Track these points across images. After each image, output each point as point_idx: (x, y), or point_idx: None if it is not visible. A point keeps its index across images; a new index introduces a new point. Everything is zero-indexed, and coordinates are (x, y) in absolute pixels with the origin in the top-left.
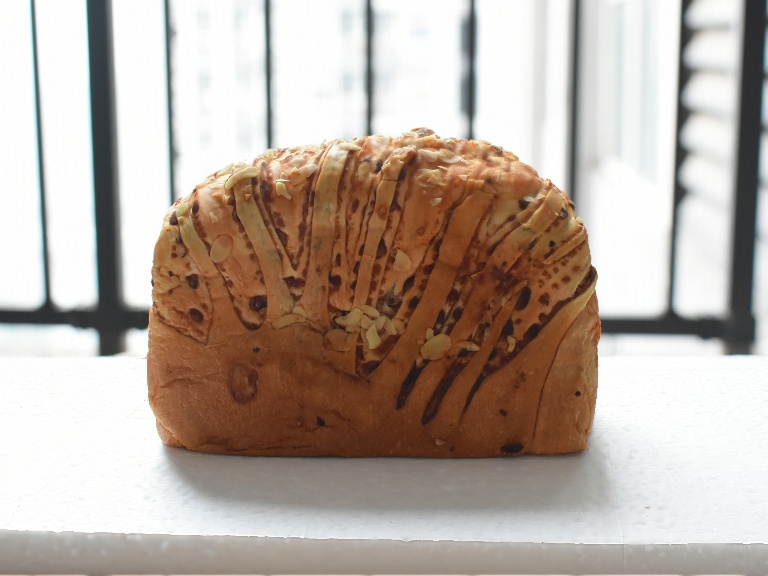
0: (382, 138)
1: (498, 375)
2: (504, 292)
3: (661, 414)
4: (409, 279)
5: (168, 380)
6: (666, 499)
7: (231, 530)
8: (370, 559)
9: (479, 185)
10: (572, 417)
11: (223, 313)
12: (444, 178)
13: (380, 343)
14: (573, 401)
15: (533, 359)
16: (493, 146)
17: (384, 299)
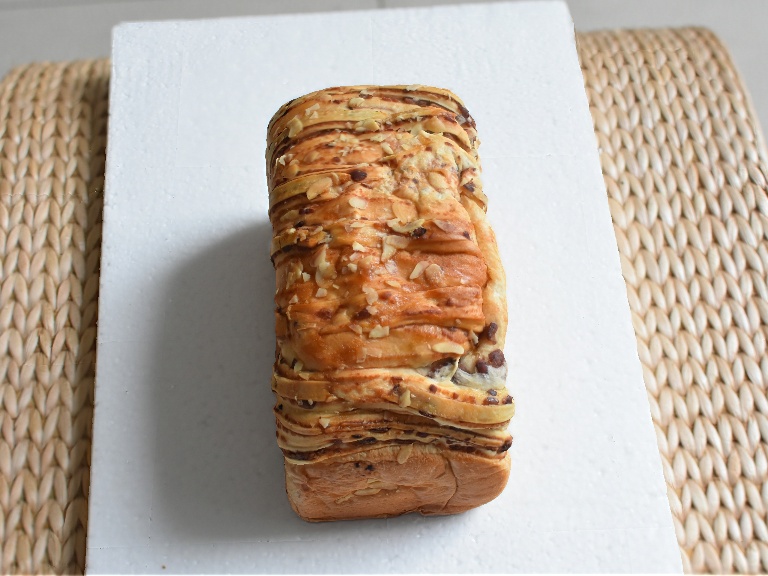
0: (345, 207)
1: None
2: None
3: None
4: None
5: None
6: None
7: (112, 298)
8: None
9: None
10: None
11: None
12: (293, 284)
13: None
14: None
15: None
16: (365, 307)
17: None
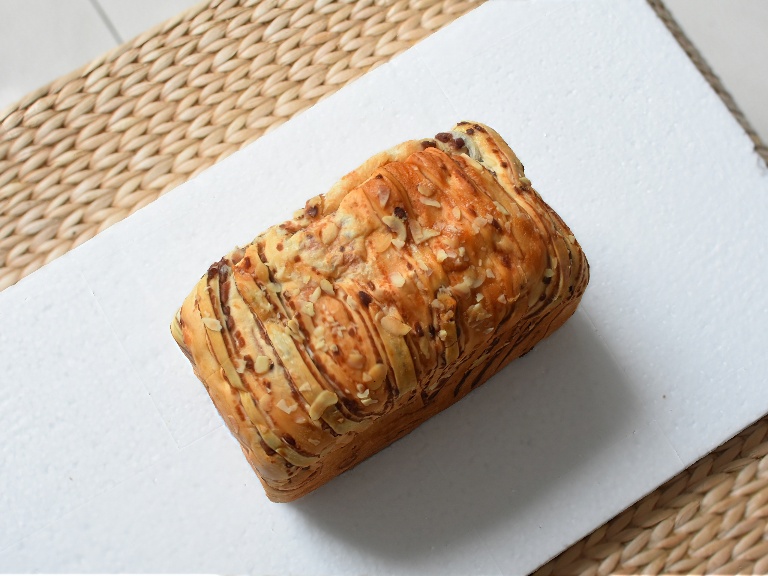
0: (408, 288)
1: None
2: None
3: (558, 179)
4: None
5: None
6: (667, 375)
7: None
8: None
9: None
10: None
11: None
12: (487, 309)
13: (438, 383)
14: None
15: None
16: (490, 225)
17: None
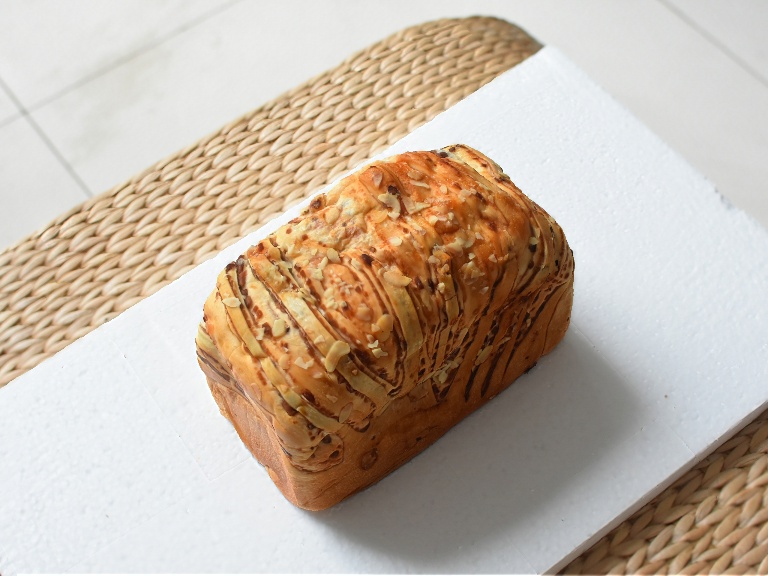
0: (405, 247)
1: (523, 343)
2: (523, 301)
3: None
4: (465, 336)
5: None
6: (665, 378)
7: None
8: None
9: (506, 259)
10: None
11: (350, 439)
12: (480, 267)
13: (447, 376)
14: None
15: (542, 321)
16: (475, 195)
17: (448, 355)
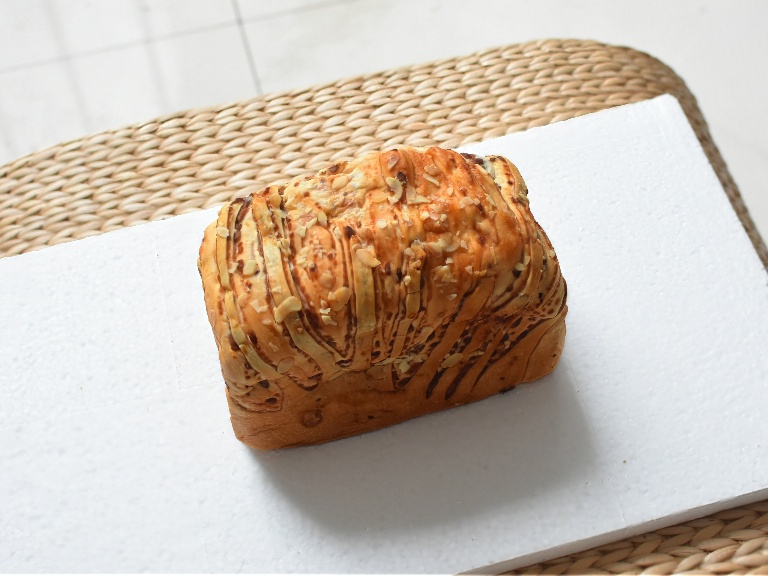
0: (387, 231)
1: (498, 363)
2: (502, 322)
3: (581, 265)
4: (431, 335)
5: (254, 433)
6: (633, 444)
7: None
8: (470, 575)
9: (483, 274)
10: (549, 366)
11: (291, 392)
12: (454, 274)
13: (410, 368)
14: (551, 360)
15: (523, 348)
16: (476, 206)
17: (411, 347)
